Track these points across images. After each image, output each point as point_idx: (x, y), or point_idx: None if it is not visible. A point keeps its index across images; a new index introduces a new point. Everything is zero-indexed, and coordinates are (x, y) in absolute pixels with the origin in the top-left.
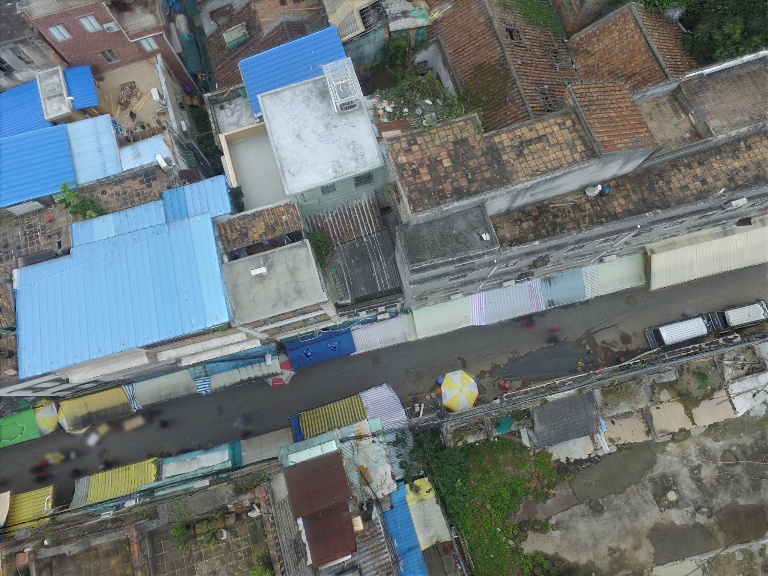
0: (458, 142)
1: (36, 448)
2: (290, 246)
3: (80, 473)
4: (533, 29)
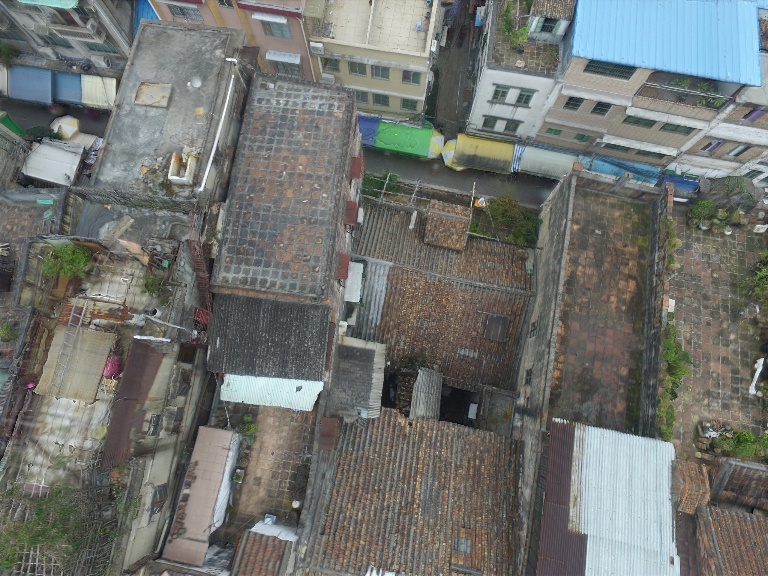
0: None
1: (399, 170)
2: None
3: None
4: None
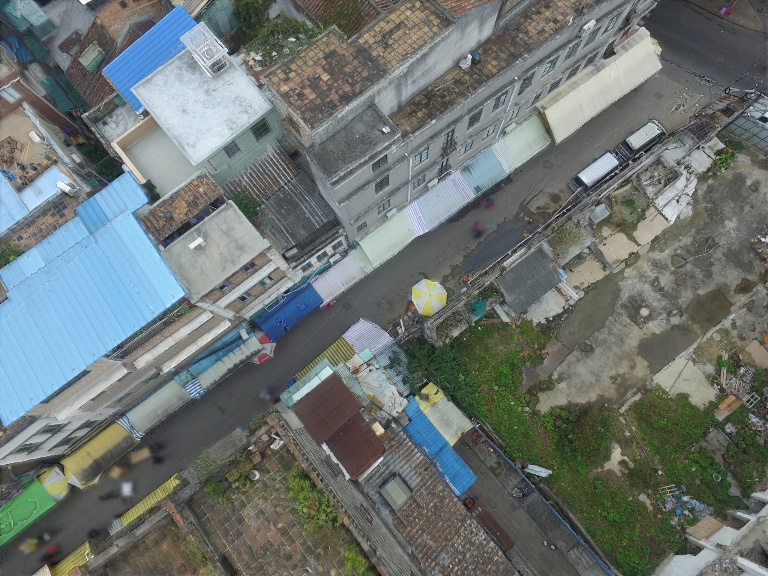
0: (328, 56)
1: (57, 520)
2: (217, 212)
3: (111, 523)
4: None
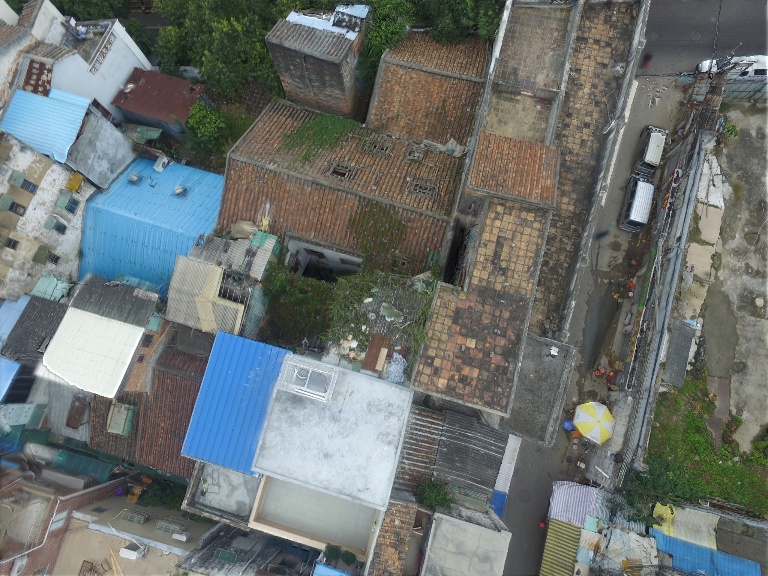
0: (456, 318)
1: None
2: (432, 536)
3: None
4: (340, 148)
